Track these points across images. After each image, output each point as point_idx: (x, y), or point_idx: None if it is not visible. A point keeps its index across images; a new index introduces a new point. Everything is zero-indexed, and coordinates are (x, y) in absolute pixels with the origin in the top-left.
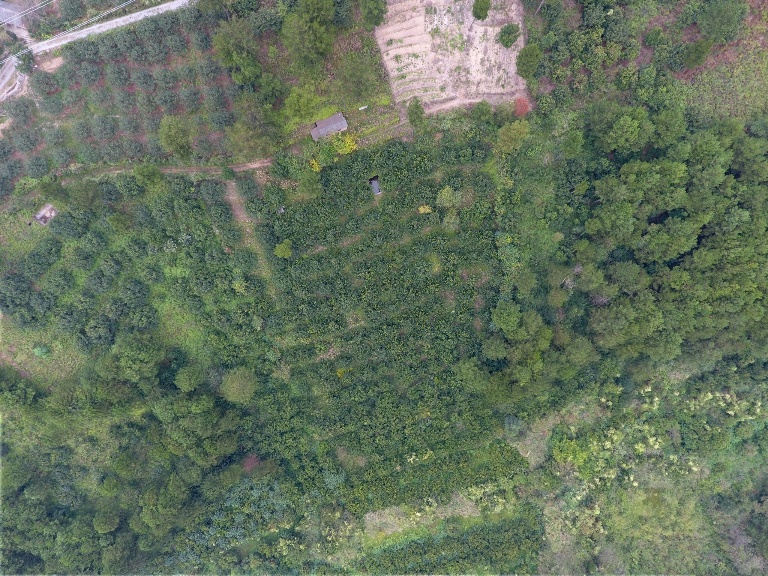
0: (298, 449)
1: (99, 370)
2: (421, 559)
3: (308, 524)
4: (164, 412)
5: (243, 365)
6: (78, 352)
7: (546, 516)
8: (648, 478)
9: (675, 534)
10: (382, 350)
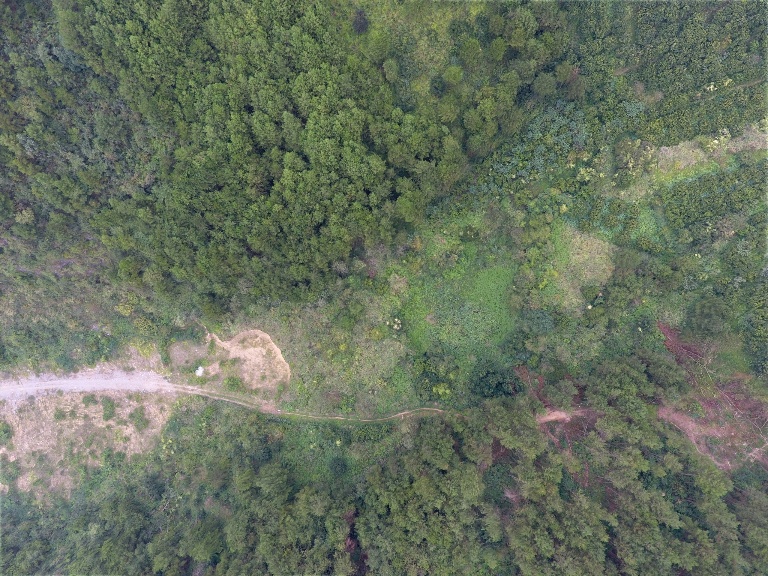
0: (602, 77)
1: None
2: (717, 186)
3: (603, 159)
4: None
5: None
6: None
7: None
8: None
9: None
10: None
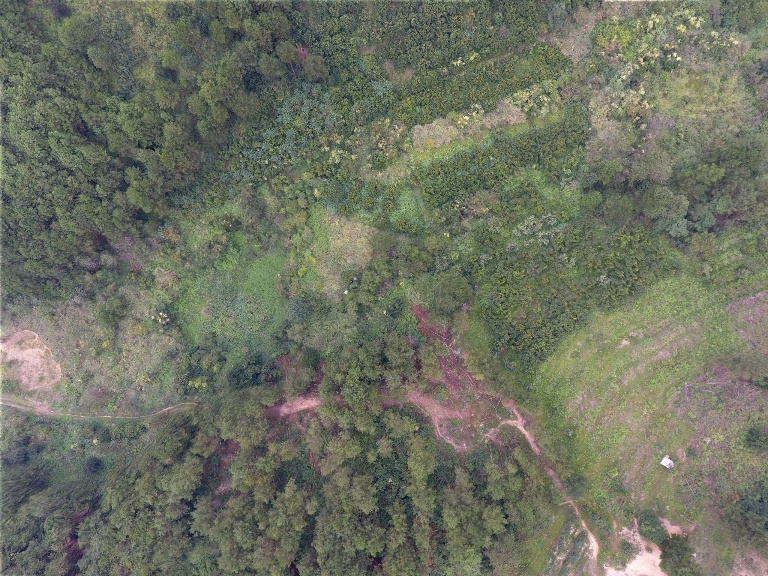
0: (347, 57)
1: None
2: (470, 163)
3: (358, 141)
4: None
5: None
6: None
7: (591, 108)
8: (690, 61)
9: (719, 108)
10: None
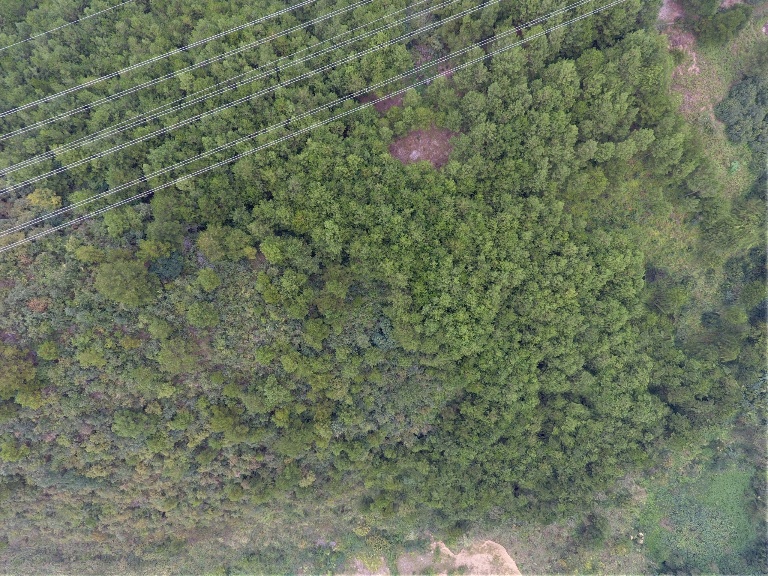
0: None
1: None
2: None
3: None
4: None
5: None
6: (754, 171)
7: None
8: None
9: None
10: None
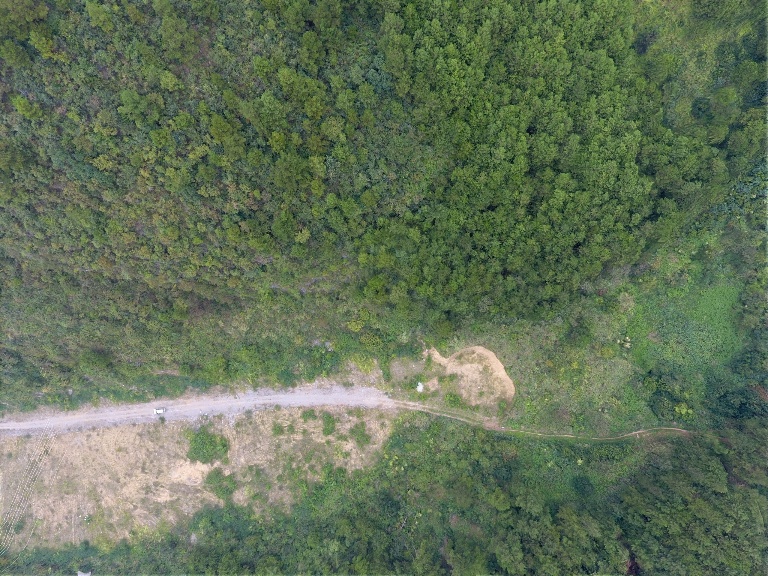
0: None
1: None
2: None
3: None
4: None
5: None
6: None
7: None
8: None
9: None
10: None
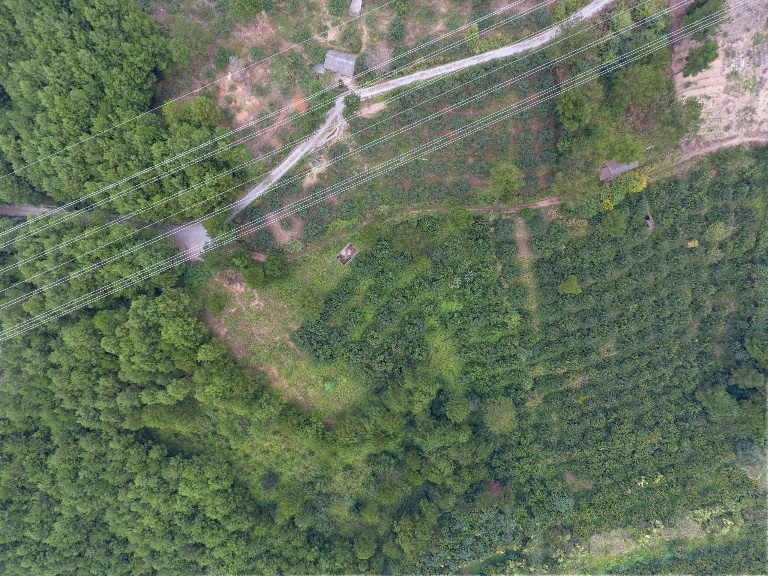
0: (530, 473)
1: (389, 404)
2: None
3: (534, 546)
4: (438, 443)
5: (502, 395)
6: (359, 385)
7: None
8: None
9: None
10: (630, 378)
